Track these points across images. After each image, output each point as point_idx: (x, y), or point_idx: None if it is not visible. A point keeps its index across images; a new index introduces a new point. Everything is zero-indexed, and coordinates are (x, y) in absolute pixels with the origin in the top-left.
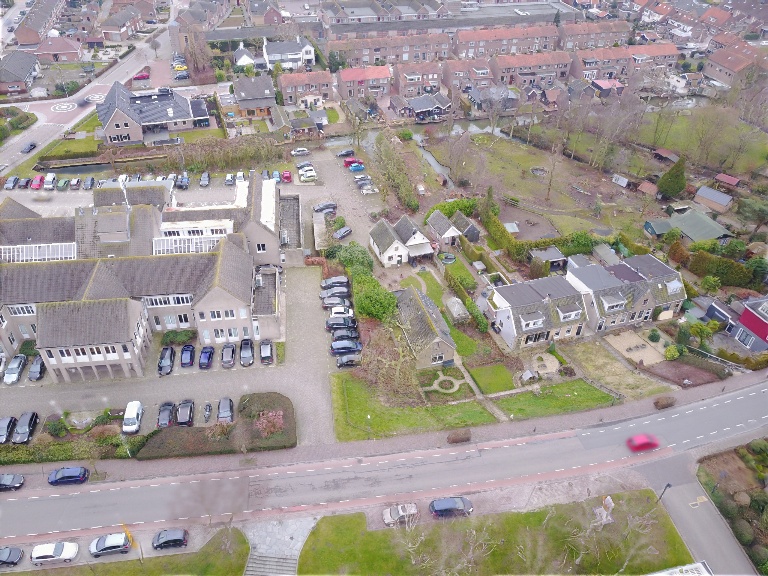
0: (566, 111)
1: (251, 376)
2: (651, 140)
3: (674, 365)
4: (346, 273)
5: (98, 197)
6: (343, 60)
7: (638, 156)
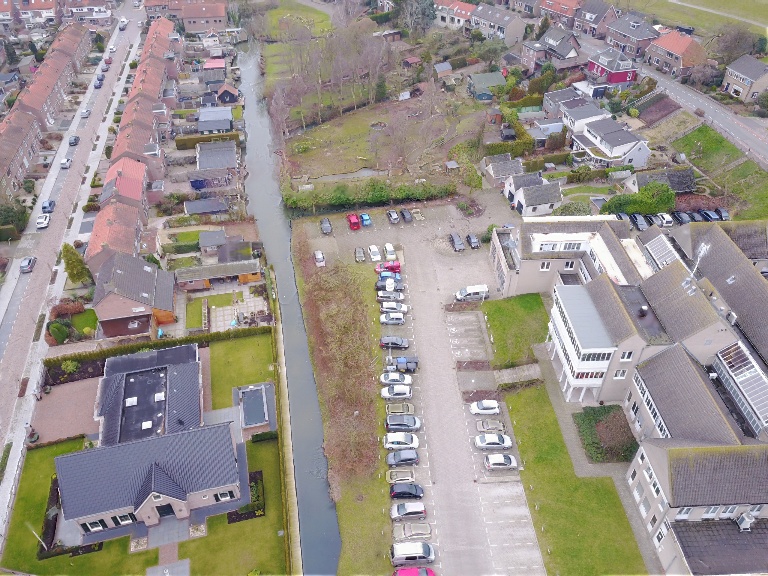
0: (247, 97)
1: (767, 263)
2: (325, 75)
3: (647, 113)
4: None
5: (641, 334)
6: (21, 205)
7: None
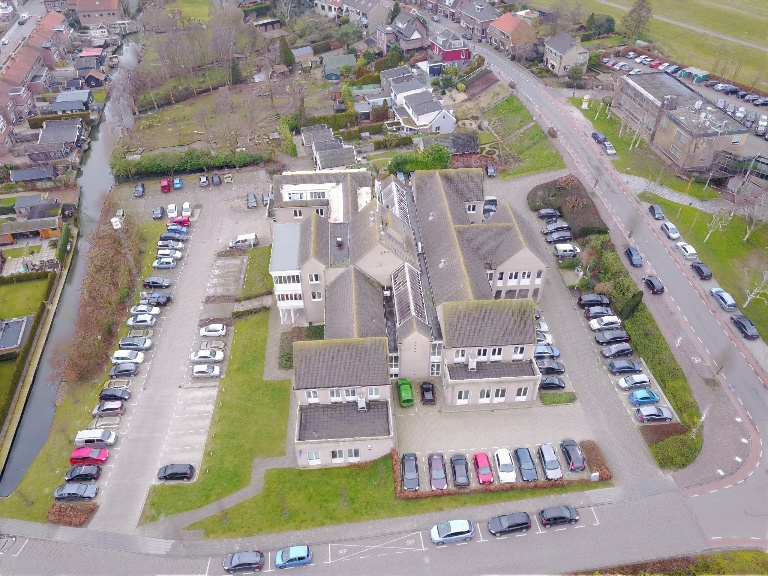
0: None
1: None
2: (197, 61)
3: (472, 87)
4: (385, 176)
5: (320, 258)
6: None
7: (220, 69)
